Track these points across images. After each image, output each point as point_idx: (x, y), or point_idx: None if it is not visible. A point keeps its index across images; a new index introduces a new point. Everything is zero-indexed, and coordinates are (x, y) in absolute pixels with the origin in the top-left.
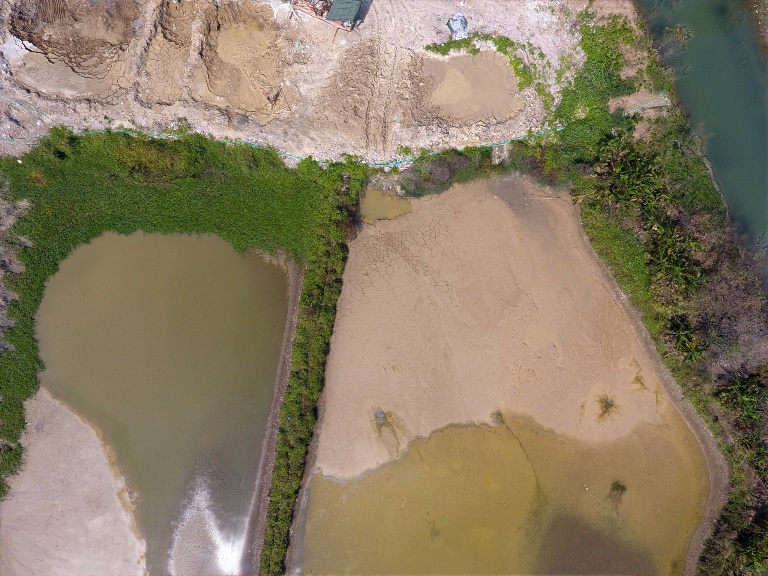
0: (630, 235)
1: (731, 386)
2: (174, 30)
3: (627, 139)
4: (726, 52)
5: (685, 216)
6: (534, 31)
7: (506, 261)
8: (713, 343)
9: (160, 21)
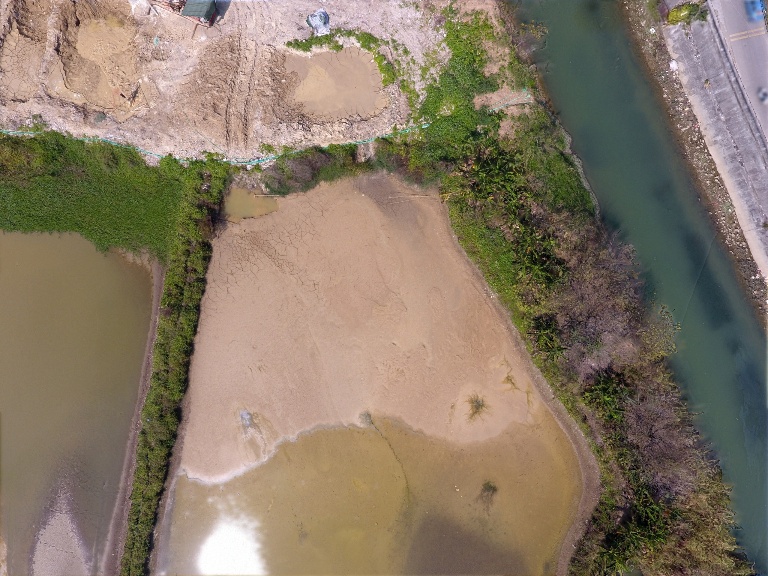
0: (496, 233)
1: (594, 386)
2: (32, 26)
3: (493, 137)
4: (600, 49)
5: (546, 214)
6: (398, 27)
7: (374, 260)
8: (577, 342)
9: (15, 17)
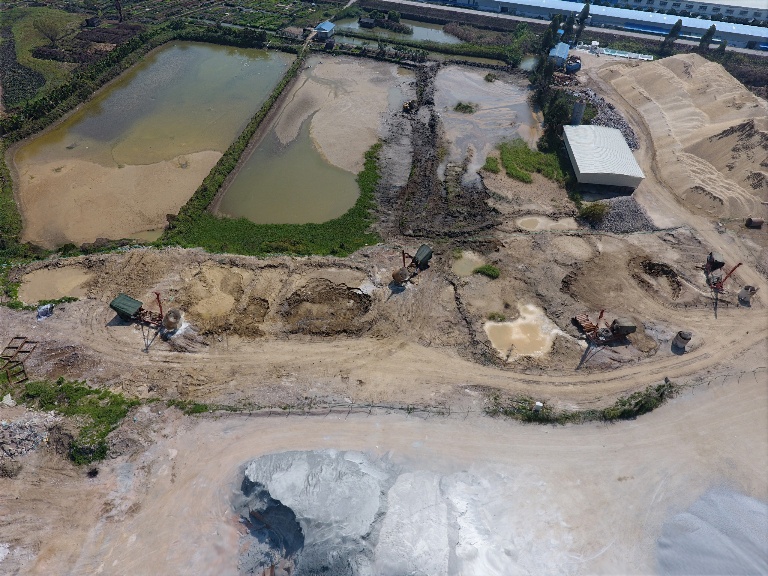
0: None
1: None
2: None
3: None
4: None
5: None
6: None
7: (82, 216)
8: None
9: None
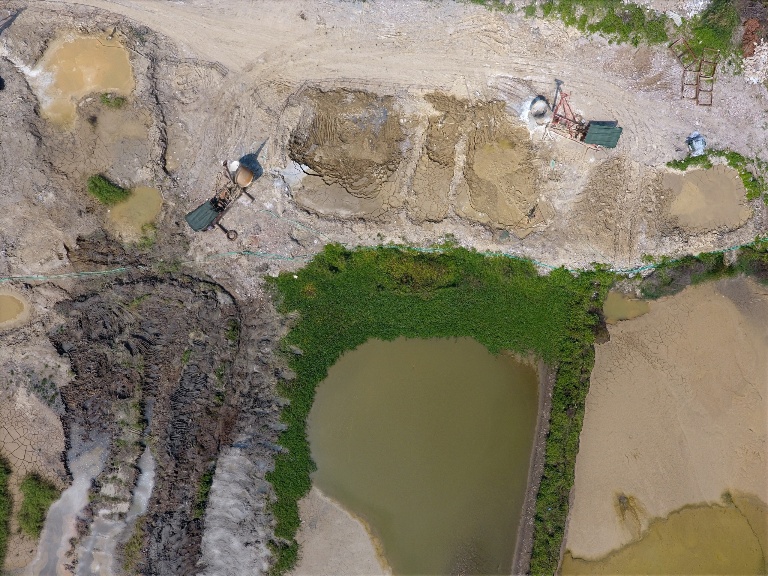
0: None
1: None
2: (435, 150)
3: None
4: None
5: None
6: (761, 147)
7: (733, 355)
8: None
9: (425, 143)
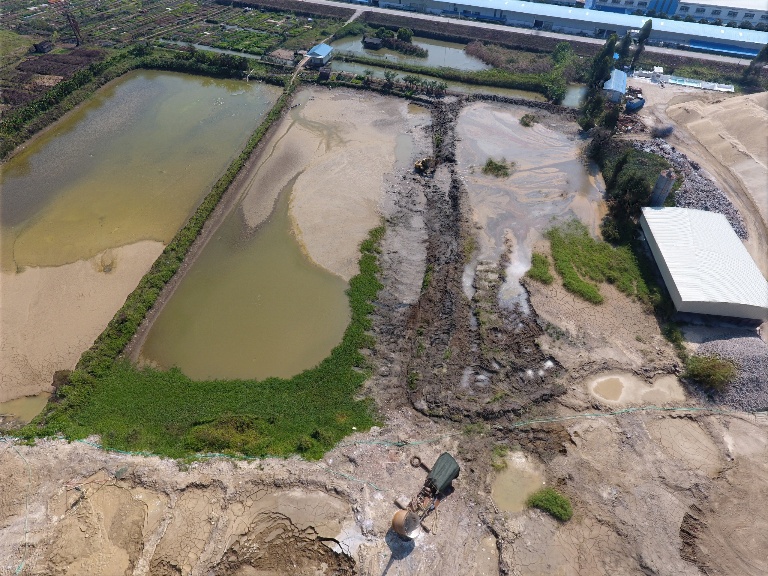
0: None
1: None
2: None
3: None
4: None
5: None
6: None
7: None
8: None
9: None
